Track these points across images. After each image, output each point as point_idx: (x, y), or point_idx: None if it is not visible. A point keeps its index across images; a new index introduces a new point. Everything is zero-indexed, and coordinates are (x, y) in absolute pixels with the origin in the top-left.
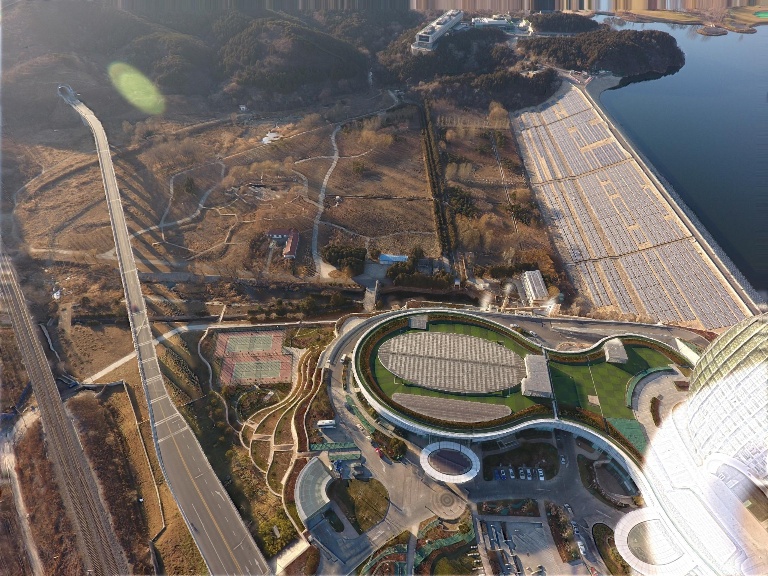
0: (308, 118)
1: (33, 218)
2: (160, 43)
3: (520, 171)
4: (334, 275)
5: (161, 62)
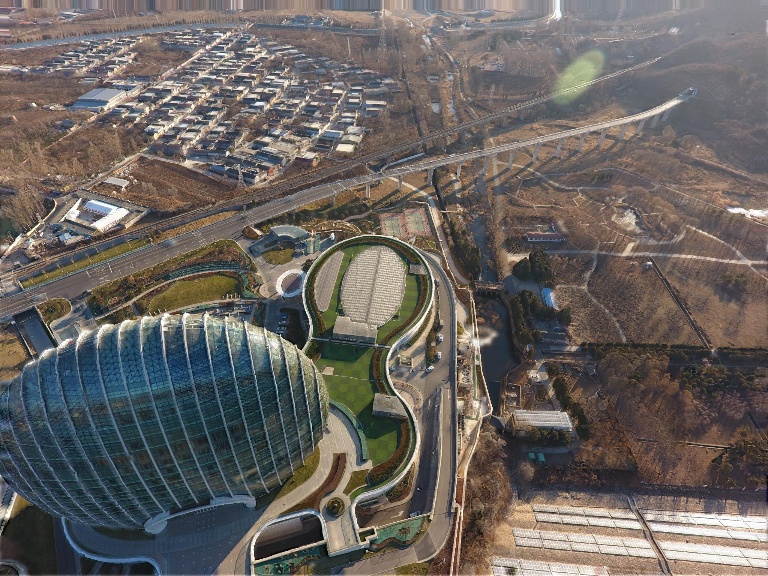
0: None
1: (524, 131)
2: None
3: None
4: (513, 264)
5: None
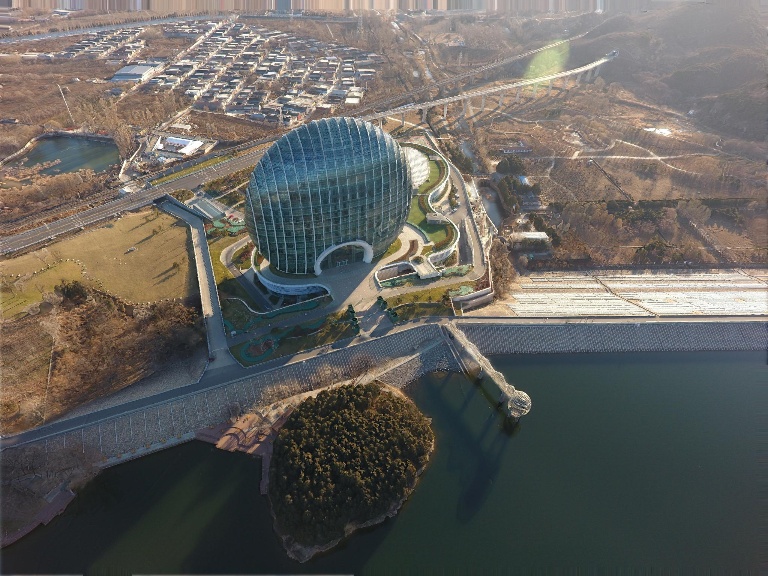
0: (704, 134)
1: (489, 87)
2: (730, 55)
3: (761, 261)
4: None
5: (701, 64)
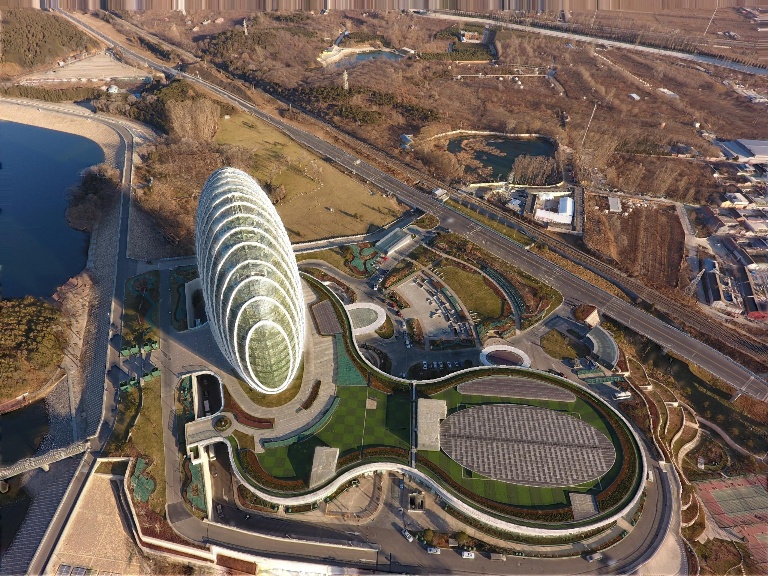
0: None
1: None
2: None
3: None
4: None
5: None
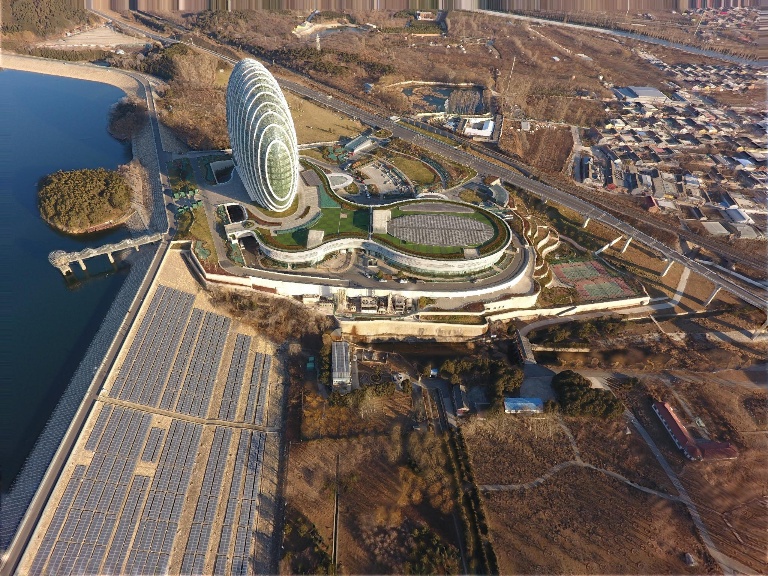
0: None
1: None
2: None
3: None
4: None
5: None
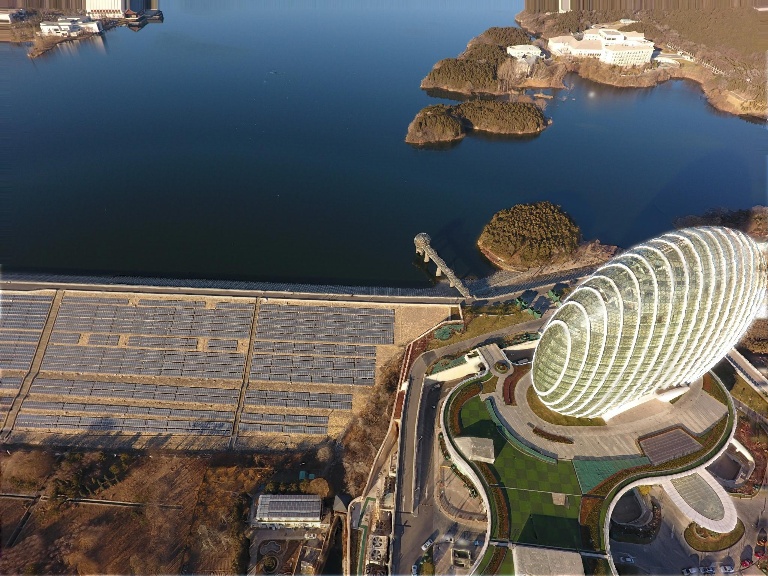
0: None
1: None
2: None
3: None
4: None
5: None
